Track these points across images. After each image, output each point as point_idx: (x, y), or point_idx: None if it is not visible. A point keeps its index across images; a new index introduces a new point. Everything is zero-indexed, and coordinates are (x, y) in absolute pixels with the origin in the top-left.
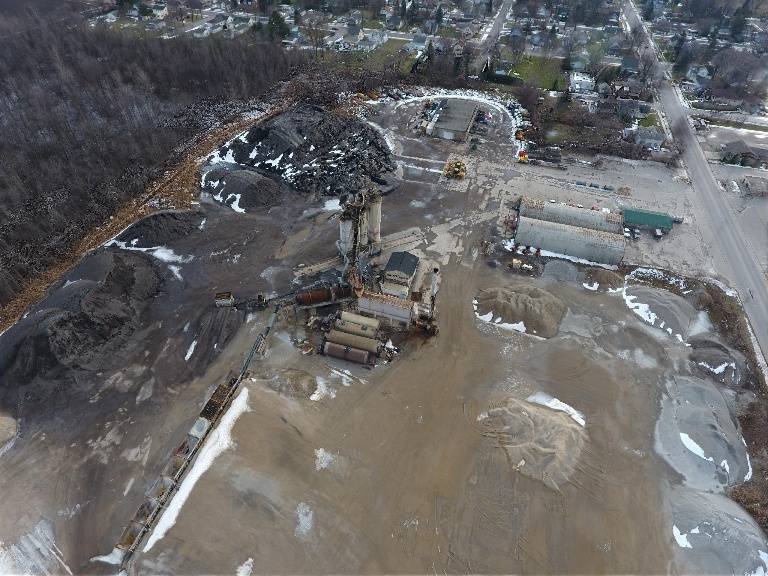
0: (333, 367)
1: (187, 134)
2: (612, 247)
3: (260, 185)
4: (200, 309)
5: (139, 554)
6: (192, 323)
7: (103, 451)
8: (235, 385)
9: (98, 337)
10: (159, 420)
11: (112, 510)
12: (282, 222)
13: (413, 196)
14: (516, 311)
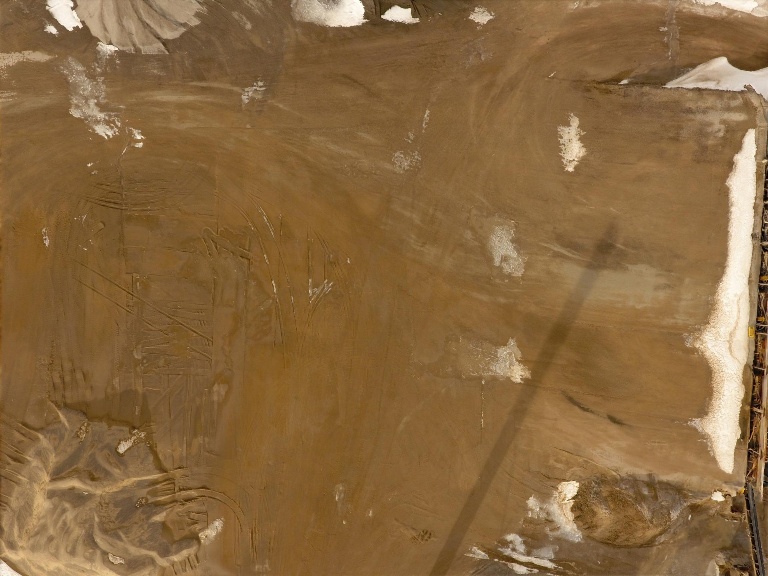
0: (555, 575)
1: None
2: None
3: None
4: None
5: (759, 124)
6: None
7: None
8: (760, 470)
9: None
10: None
11: None
12: None
13: None
14: None
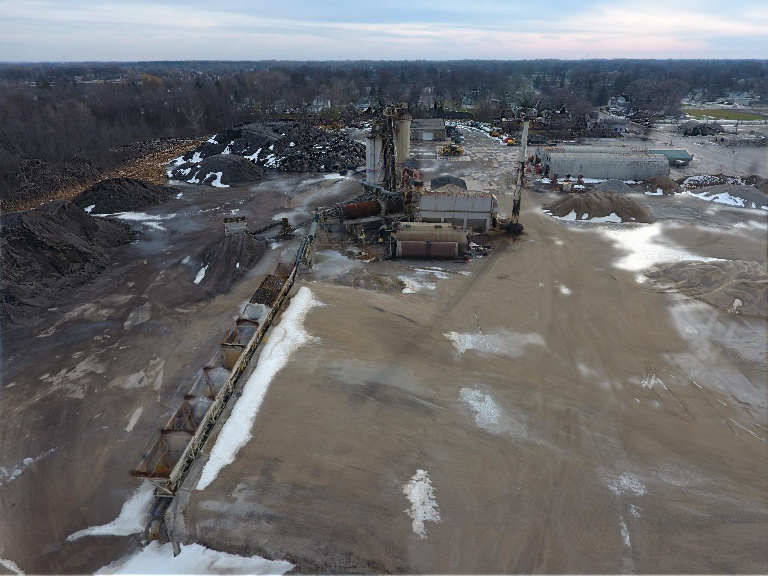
0: (414, 267)
1: (139, 154)
2: (655, 162)
3: (244, 164)
4: (200, 246)
5: (189, 494)
6: (193, 256)
7: (73, 384)
8: (289, 280)
9: (49, 267)
10: (171, 339)
11: (106, 454)
12: (280, 188)
13: (418, 166)
14: (602, 203)
